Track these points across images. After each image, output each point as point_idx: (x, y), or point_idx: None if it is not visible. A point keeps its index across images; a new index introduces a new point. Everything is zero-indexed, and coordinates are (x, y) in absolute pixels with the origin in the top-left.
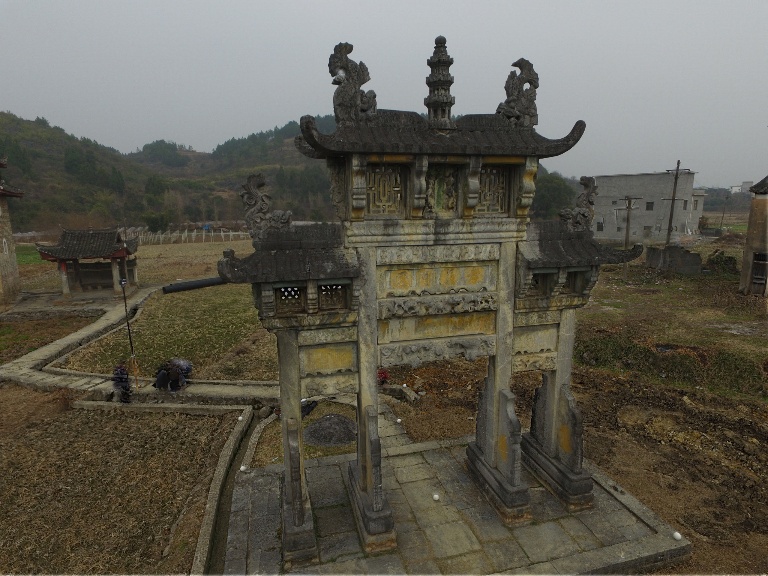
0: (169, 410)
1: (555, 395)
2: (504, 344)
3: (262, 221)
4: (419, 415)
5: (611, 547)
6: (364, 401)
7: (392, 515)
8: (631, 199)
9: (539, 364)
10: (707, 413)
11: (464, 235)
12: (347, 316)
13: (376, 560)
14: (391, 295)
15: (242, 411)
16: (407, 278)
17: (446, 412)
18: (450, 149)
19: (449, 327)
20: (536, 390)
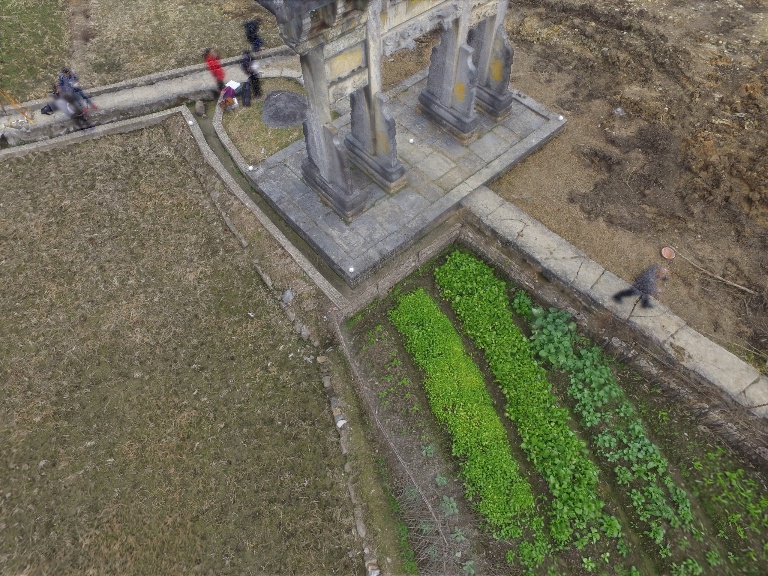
0: (96, 135)
1: (493, 36)
2: (467, 3)
3: None
4: None
5: (527, 138)
6: (373, 90)
7: None
8: None
9: (488, 13)
10: (560, 3)
11: None
12: (360, 18)
13: (399, 195)
14: None
15: (180, 114)
16: None
17: None
18: None
19: None
20: (471, 31)
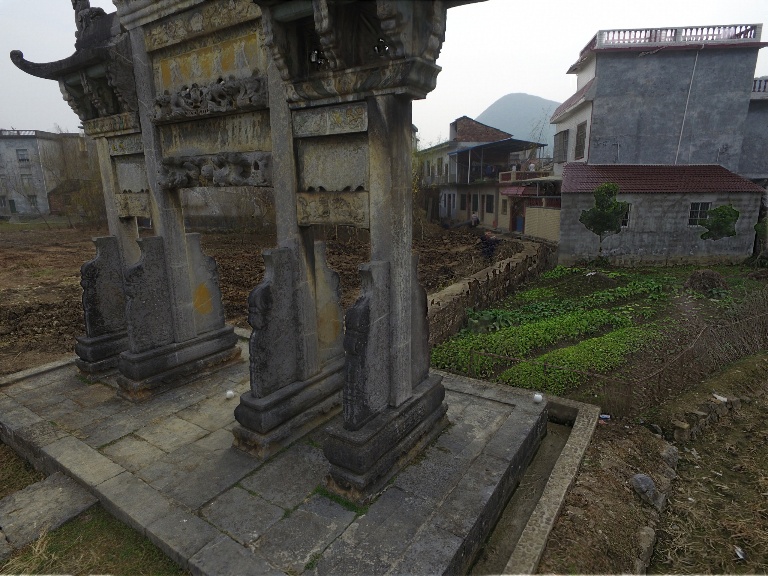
0: None
1: None
2: None
3: None
4: None
5: None
6: None
7: None
8: None
9: None
10: None
11: None
12: None
13: None
14: None
15: None
16: None
17: None
18: None
19: None
20: (90, 267)
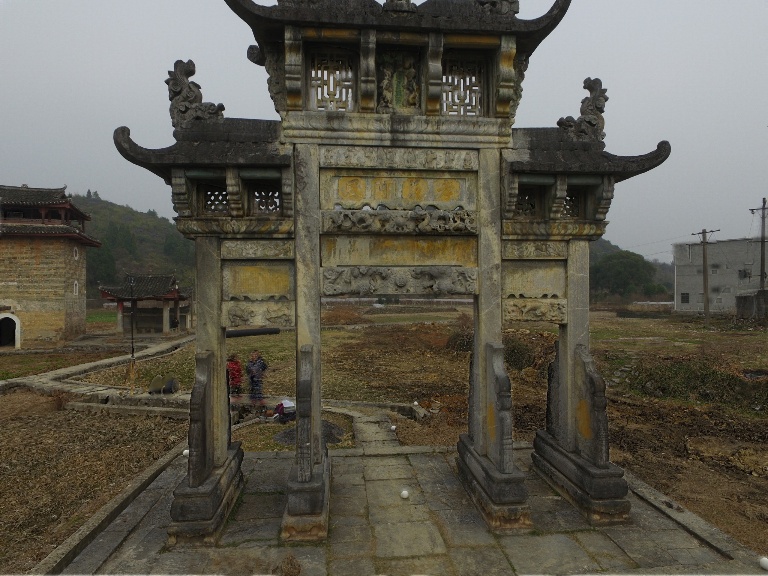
0: (153, 413)
1: (568, 359)
2: (489, 280)
3: (187, 110)
4: (424, 430)
5: (651, 569)
6: (301, 338)
7: (339, 507)
8: (705, 232)
9: (540, 311)
10: None
11: (429, 136)
12: (280, 224)
13: (292, 550)
14: (339, 207)
15: None
16: (359, 187)
17: (458, 429)
18: (401, 21)
19: (415, 253)
20: None
